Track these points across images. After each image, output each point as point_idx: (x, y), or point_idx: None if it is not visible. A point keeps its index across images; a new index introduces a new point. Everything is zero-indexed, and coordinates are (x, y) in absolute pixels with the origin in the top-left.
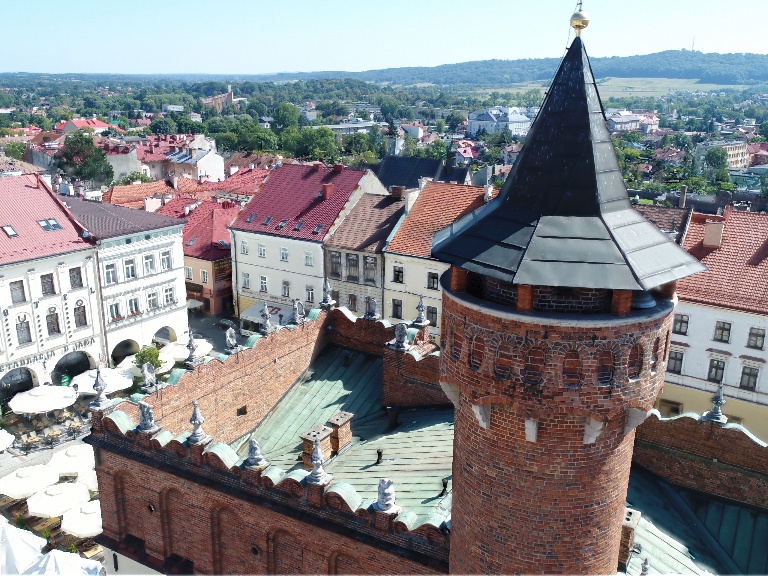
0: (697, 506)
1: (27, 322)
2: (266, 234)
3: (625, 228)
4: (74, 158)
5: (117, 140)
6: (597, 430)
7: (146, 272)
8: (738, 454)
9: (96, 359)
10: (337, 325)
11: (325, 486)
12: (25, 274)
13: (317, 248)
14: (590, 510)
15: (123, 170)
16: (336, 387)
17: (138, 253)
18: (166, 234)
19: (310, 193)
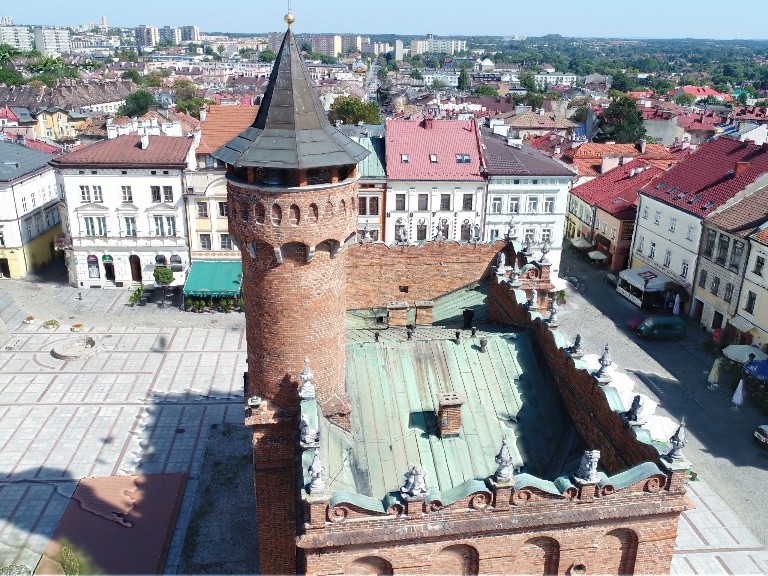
0: (576, 451)
1: (426, 225)
2: (662, 202)
3: (271, 138)
4: (614, 119)
5: (697, 108)
6: (246, 247)
7: (529, 211)
8: (602, 413)
9: None
10: (510, 255)
11: None
12: (430, 190)
13: (698, 223)
14: (262, 301)
15: (659, 135)
16: (480, 298)
17: (524, 193)
18: (553, 182)
19: (724, 169)
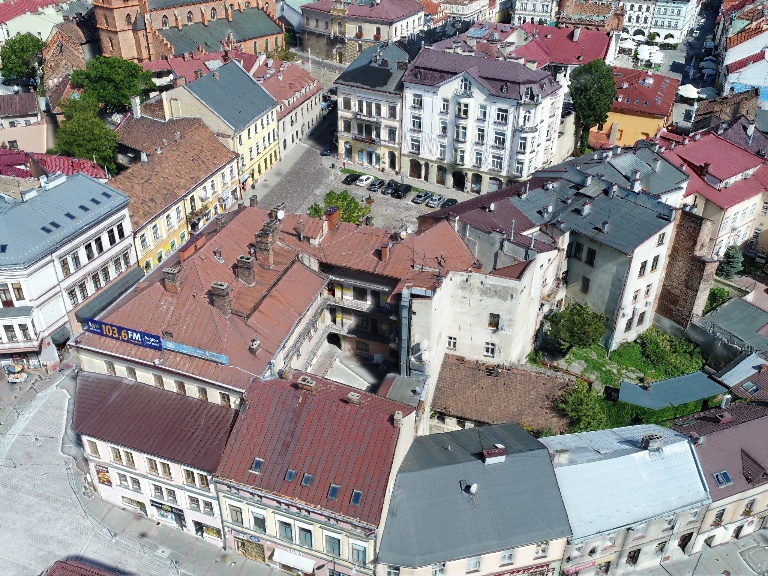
0: None
1: None
2: None
3: None
4: None
5: None
6: None
7: None
8: None
9: None
10: None
11: None
12: (635, 3)
13: None
14: None
15: None
16: None
17: (670, 7)
18: (681, 4)
19: None
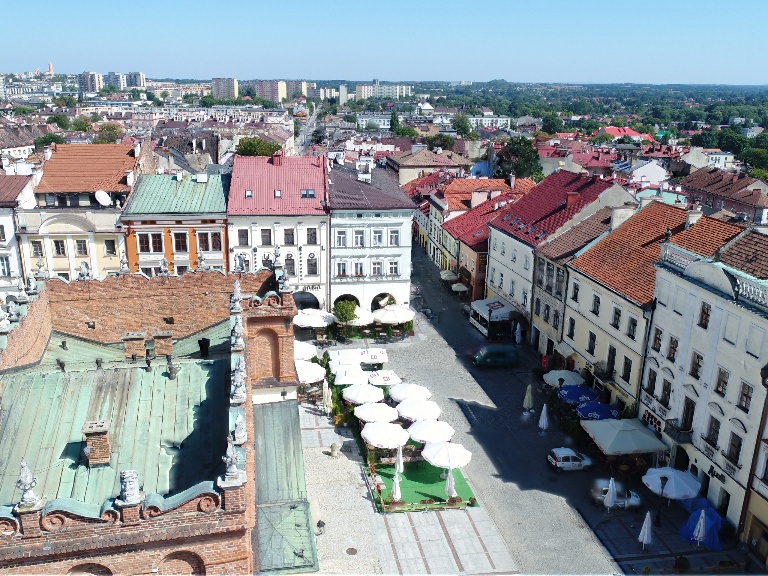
0: None
1: (271, 260)
2: (505, 233)
3: None
4: (512, 157)
5: None
6: None
7: (375, 244)
8: None
9: (321, 302)
10: None
11: (2, 334)
12: (273, 225)
13: None
14: None
15: None
16: None
17: (368, 227)
18: (396, 215)
19: (560, 200)
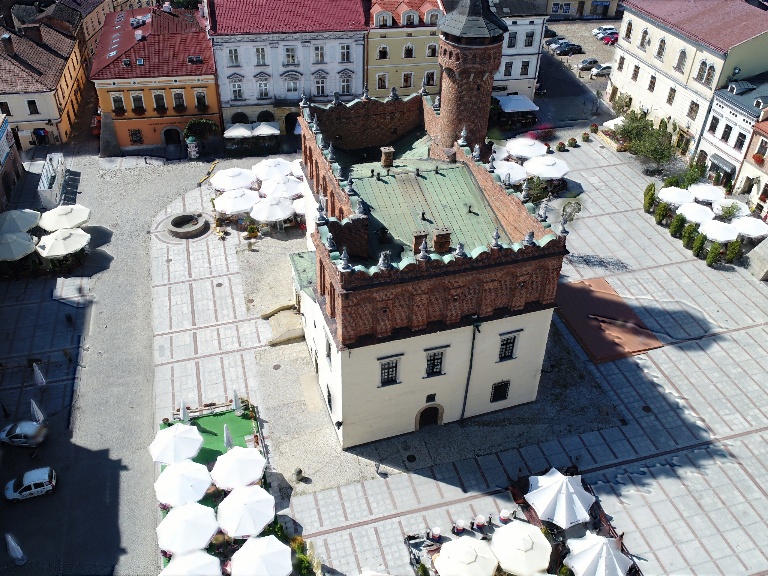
0: None
1: None
2: None
3: None
4: None
5: None
6: None
7: None
8: None
9: None
10: None
11: None
12: None
13: None
14: None
15: None
16: None
17: None
18: None
19: None
